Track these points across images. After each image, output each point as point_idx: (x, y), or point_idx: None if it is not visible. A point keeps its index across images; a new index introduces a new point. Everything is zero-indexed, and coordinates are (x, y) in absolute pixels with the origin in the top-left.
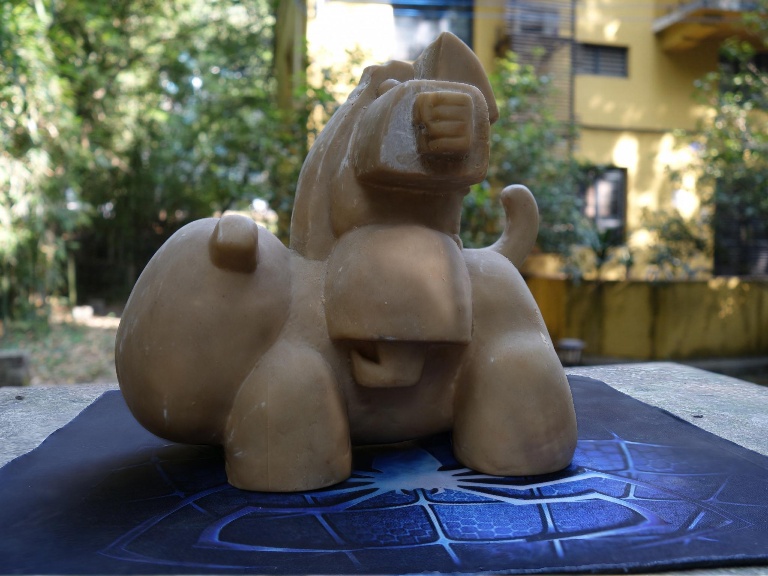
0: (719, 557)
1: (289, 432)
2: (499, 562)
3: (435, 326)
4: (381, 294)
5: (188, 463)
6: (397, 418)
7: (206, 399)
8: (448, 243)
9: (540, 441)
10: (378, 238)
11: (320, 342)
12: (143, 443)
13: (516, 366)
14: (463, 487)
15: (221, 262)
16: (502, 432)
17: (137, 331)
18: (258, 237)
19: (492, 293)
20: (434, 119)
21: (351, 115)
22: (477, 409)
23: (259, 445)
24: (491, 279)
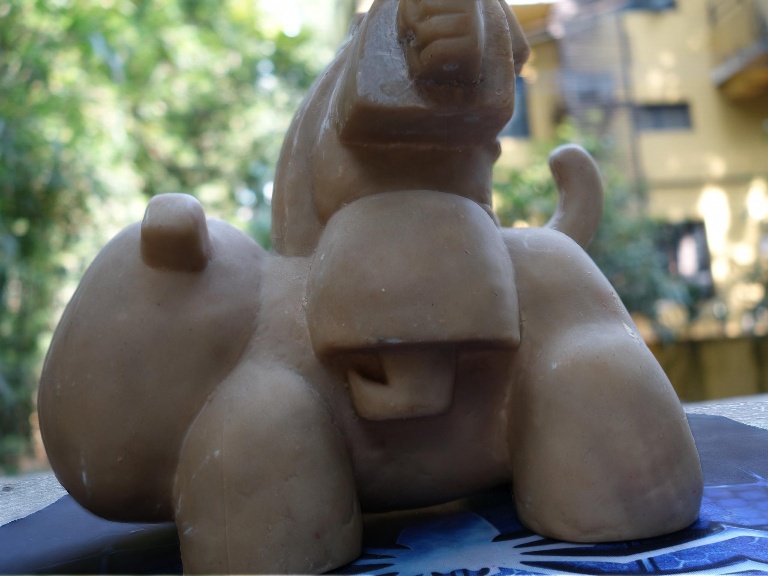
0: None
1: (255, 492)
2: None
3: (459, 318)
4: (376, 279)
5: (146, 552)
6: (427, 467)
7: (138, 452)
8: (471, 206)
9: (644, 483)
10: (369, 207)
11: (302, 361)
12: (107, 530)
13: (591, 371)
14: (529, 563)
15: (153, 258)
16: (582, 473)
17: (50, 365)
18: (212, 228)
19: (544, 274)
20: (422, 17)
21: (334, 71)
22: (540, 441)
23: (213, 515)
24: (541, 255)
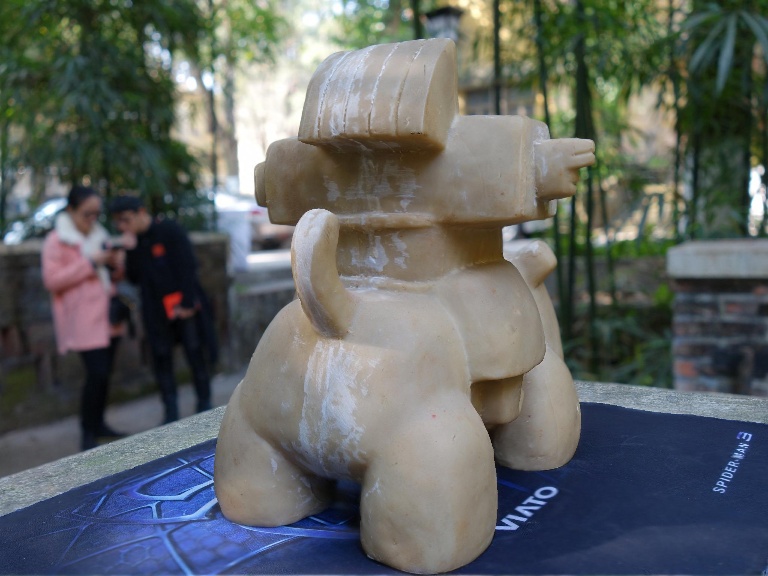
0: (88, 484)
1: None
2: (206, 447)
3: None
4: None
5: None
6: None
7: None
8: None
9: None
10: None
11: None
12: None
13: None
14: None
15: None
16: None
17: None
18: None
19: None
20: None
21: None
22: None
23: None
24: None
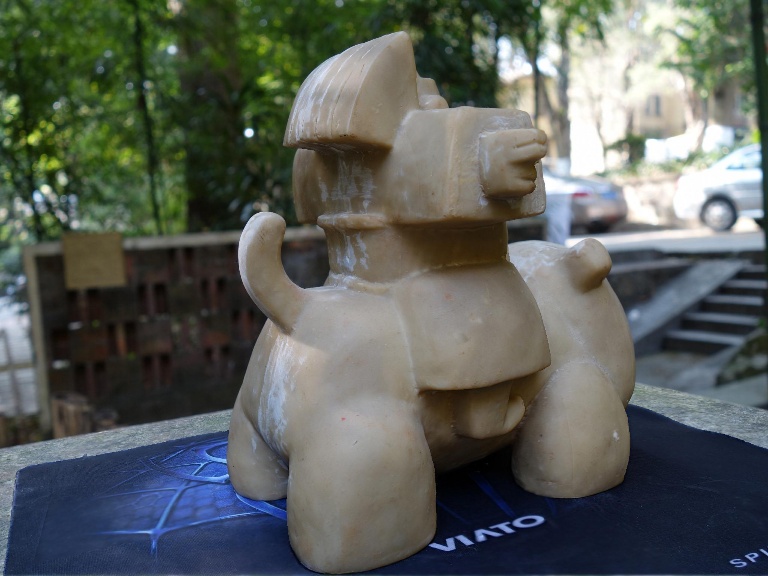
0: (184, 438)
1: None
2: None
3: None
4: None
5: None
6: None
7: None
8: None
9: None
10: None
11: None
12: (634, 446)
13: None
14: None
15: None
16: None
17: None
18: None
19: None
20: None
21: None
22: None
23: None
24: None
